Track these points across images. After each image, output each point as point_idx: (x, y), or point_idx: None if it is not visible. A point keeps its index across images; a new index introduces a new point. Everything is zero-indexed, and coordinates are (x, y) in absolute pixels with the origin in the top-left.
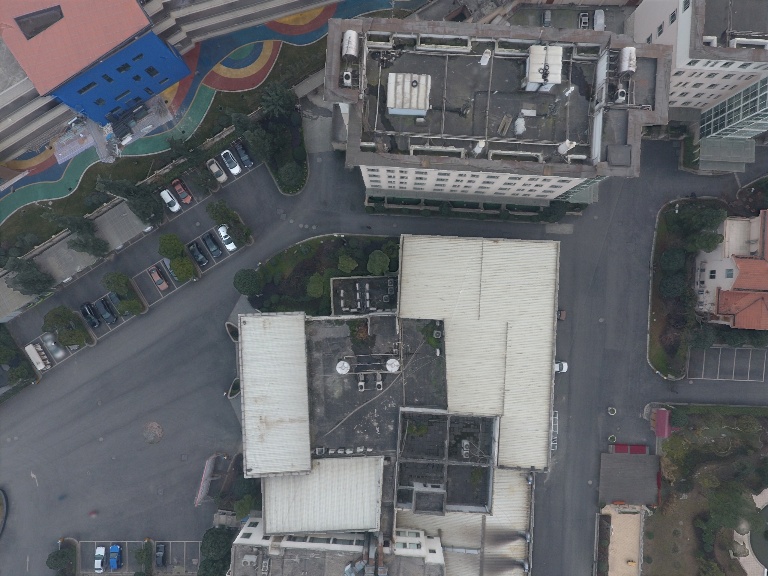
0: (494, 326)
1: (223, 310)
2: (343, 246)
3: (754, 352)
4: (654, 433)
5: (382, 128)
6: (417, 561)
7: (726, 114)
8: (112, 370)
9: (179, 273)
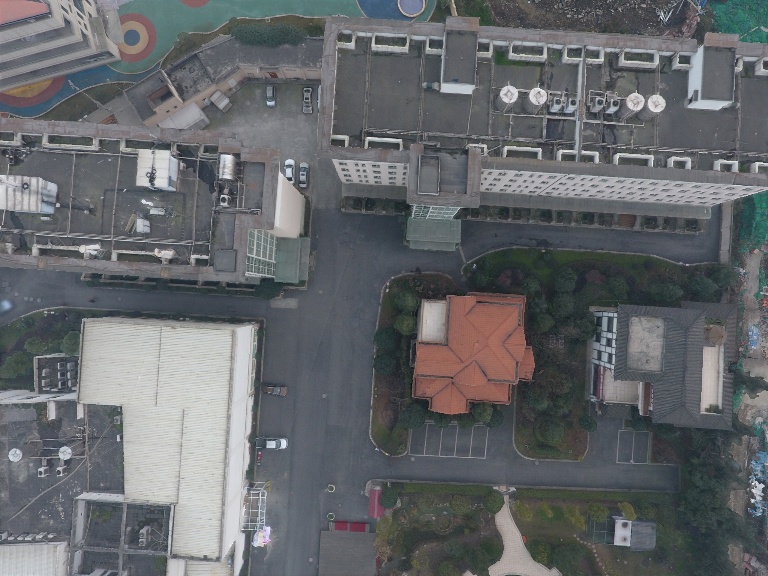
0: (171, 413)
1: None
2: (61, 321)
3: (476, 429)
4: None
5: (11, 225)
6: None
7: None
8: None
9: None
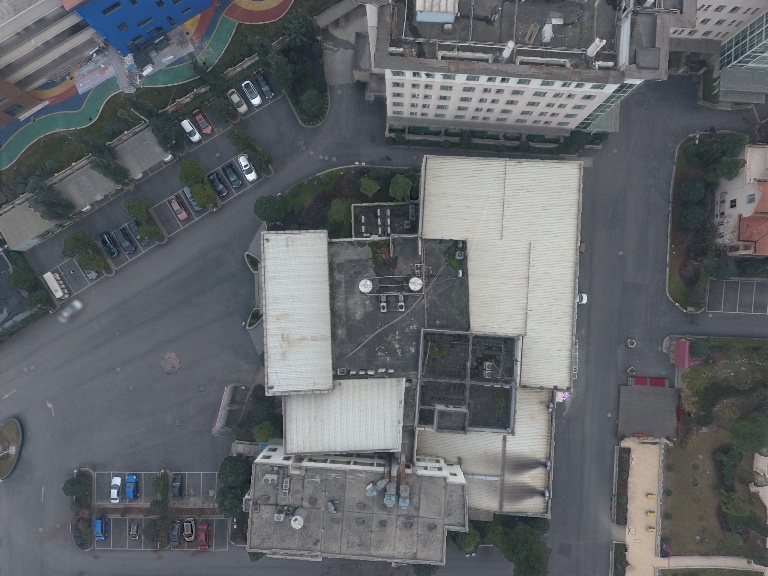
0: (517, 246)
1: (242, 241)
2: (363, 176)
3: None
4: (673, 366)
5: (410, 35)
6: (438, 482)
7: (748, 39)
8: (130, 300)
9: (200, 198)
